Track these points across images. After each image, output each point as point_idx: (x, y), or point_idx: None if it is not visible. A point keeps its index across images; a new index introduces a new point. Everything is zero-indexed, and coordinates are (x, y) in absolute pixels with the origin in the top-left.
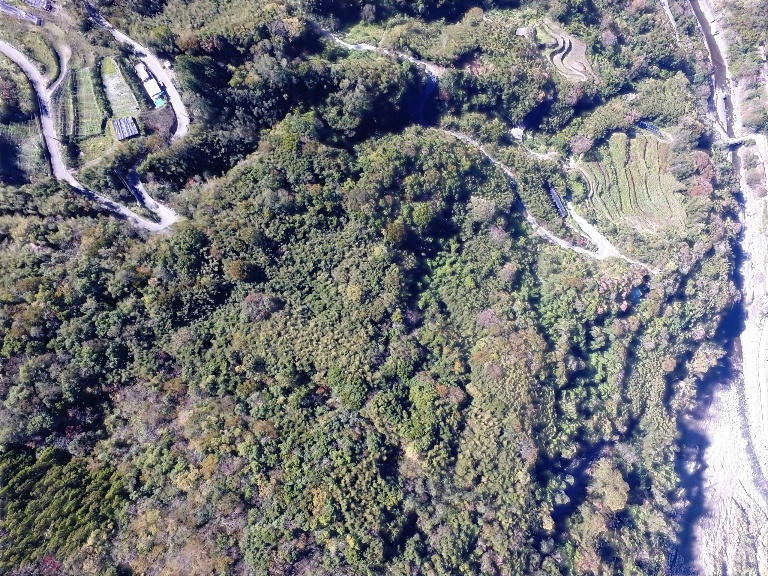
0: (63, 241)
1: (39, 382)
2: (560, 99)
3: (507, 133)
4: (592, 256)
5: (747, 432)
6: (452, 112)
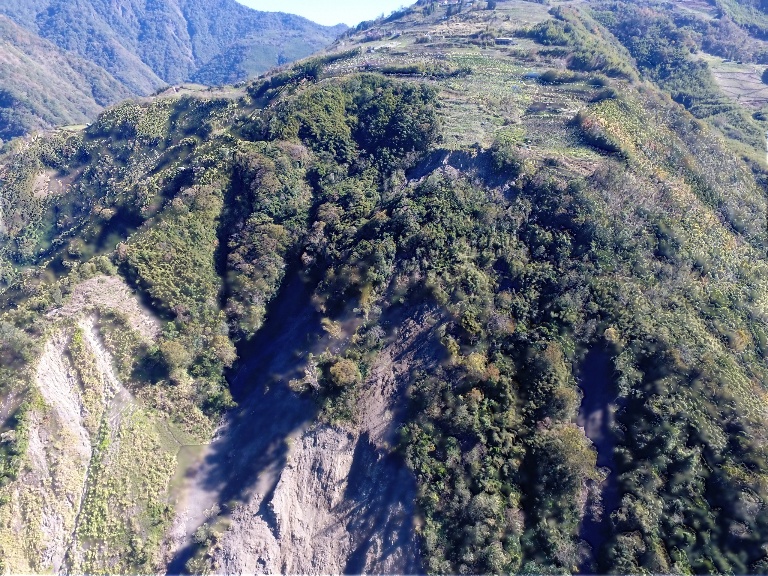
0: None
1: None
2: None
3: None
4: None
5: None
6: None
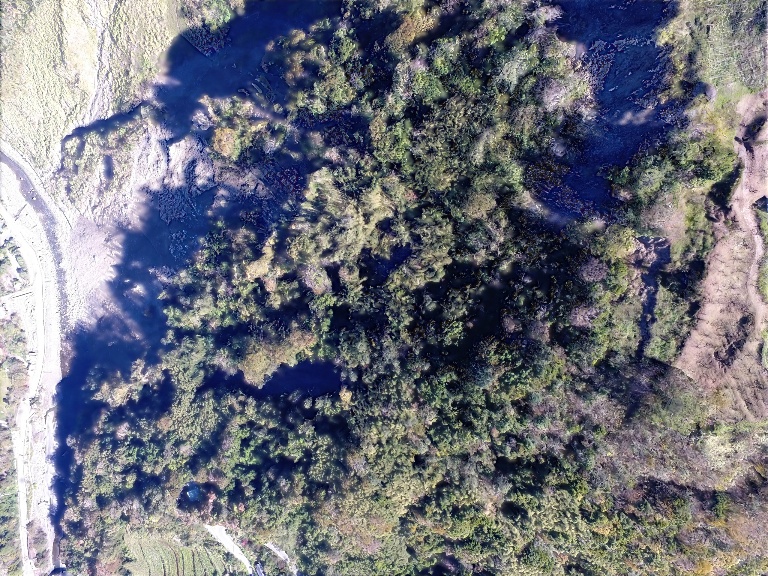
0: None
1: None
2: None
3: None
4: None
5: (60, 277)
6: None
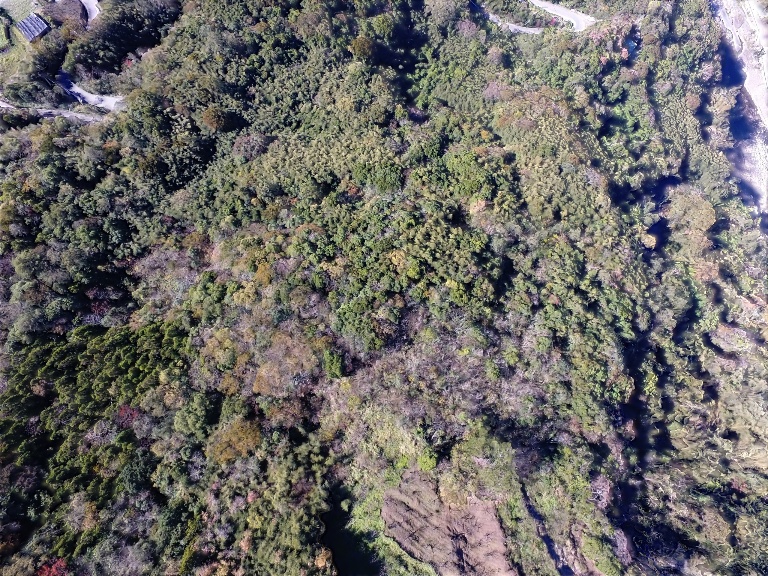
0: (11, 151)
1: (40, 273)
2: None
3: None
4: None
5: None
6: None
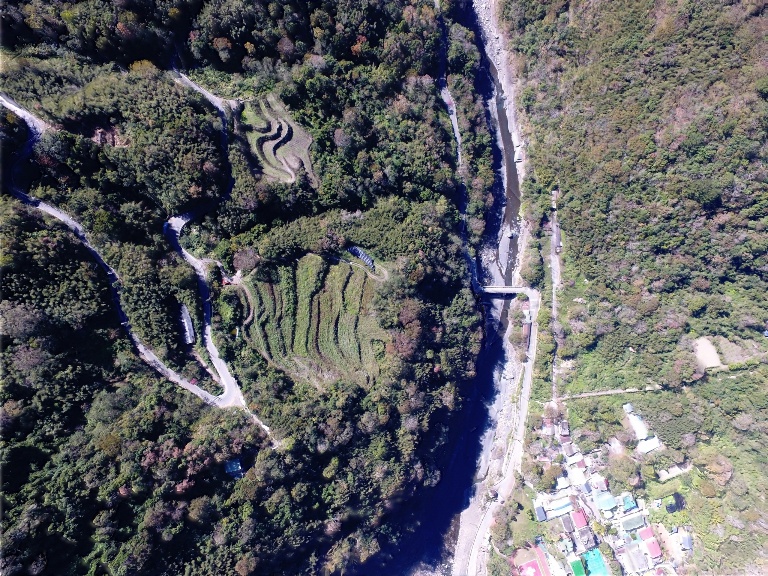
0: None
1: None
2: (232, 198)
3: (139, 224)
4: (212, 400)
5: None
6: (65, 181)
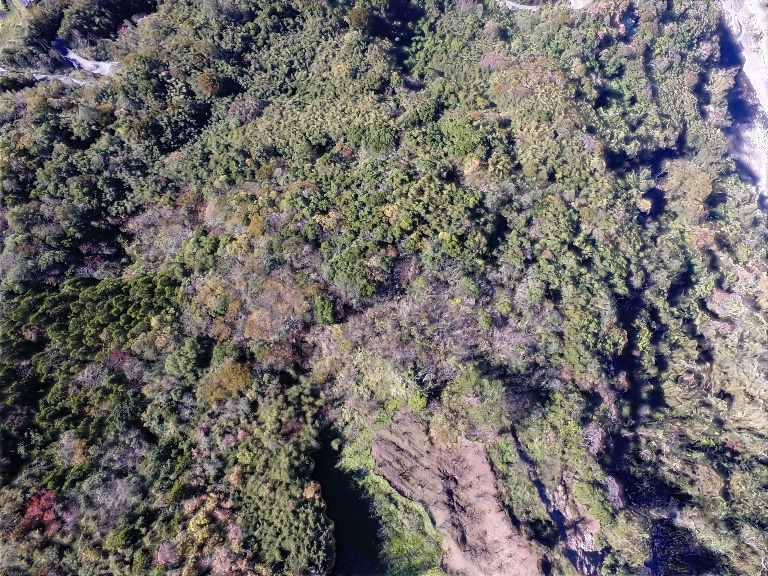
0: (6, 112)
1: (34, 227)
2: None
3: None
4: None
5: None
6: None
